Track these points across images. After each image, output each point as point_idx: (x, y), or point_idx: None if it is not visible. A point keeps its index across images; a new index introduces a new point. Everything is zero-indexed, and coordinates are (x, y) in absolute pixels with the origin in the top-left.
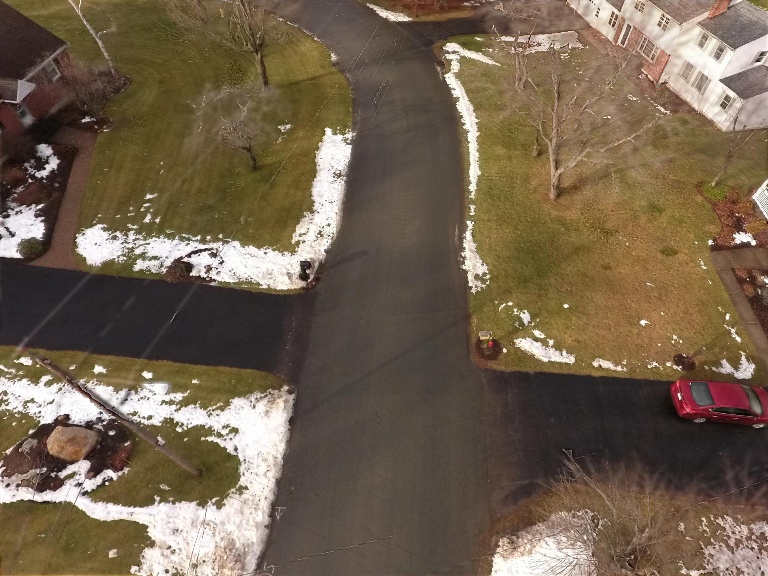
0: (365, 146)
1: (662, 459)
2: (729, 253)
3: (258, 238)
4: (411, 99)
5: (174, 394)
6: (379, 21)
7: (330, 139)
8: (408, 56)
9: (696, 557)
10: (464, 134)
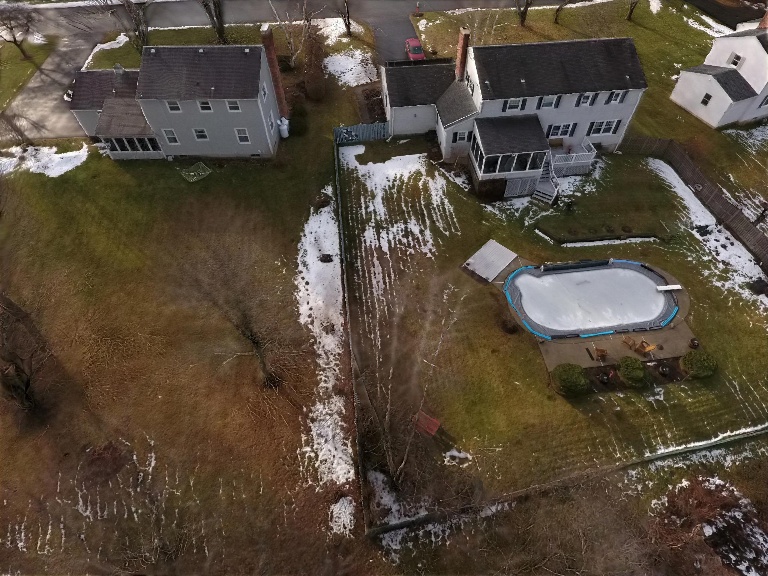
0: None
1: None
2: None
3: None
4: None
5: None
6: None
7: None
8: None
9: None
10: None
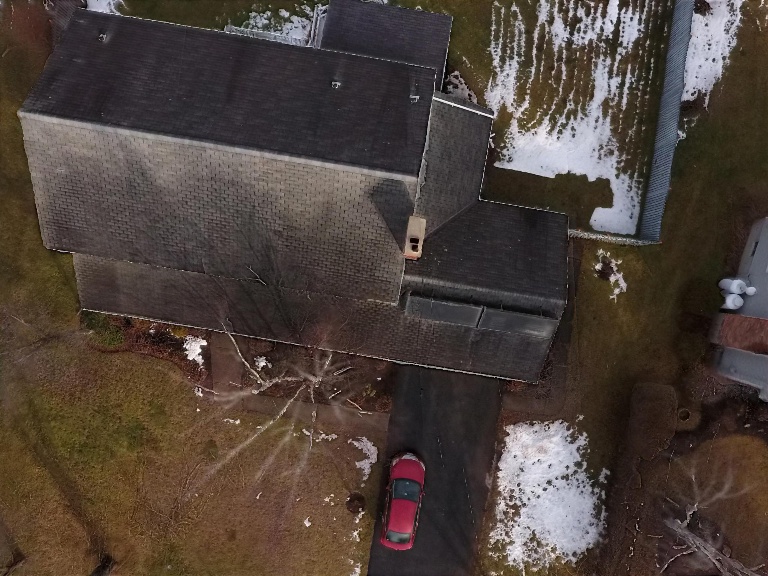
0: None
1: (443, 567)
2: (217, 380)
3: None
4: None
5: None
6: None
7: None
8: None
9: (514, 573)
10: None
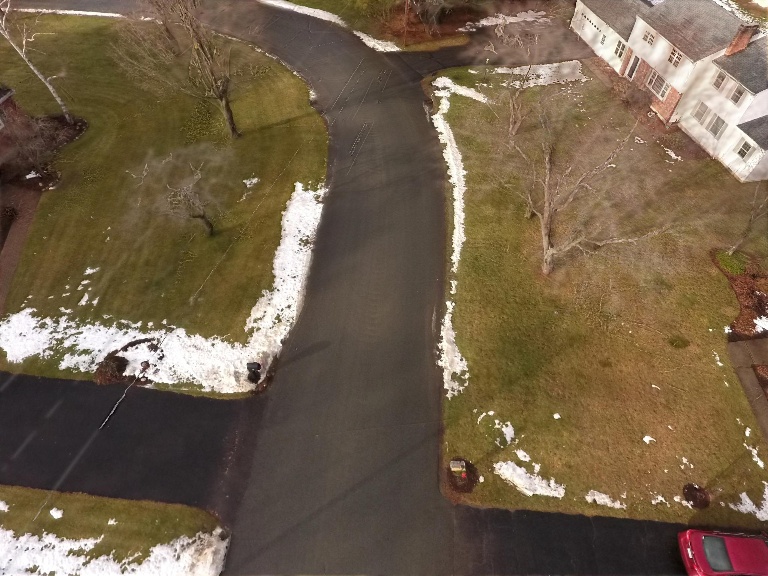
0: (338, 205)
1: None
2: (749, 344)
3: (207, 324)
4: (393, 146)
5: (85, 540)
6: (365, 52)
7: (299, 196)
8: (393, 93)
9: None
10: (449, 189)
